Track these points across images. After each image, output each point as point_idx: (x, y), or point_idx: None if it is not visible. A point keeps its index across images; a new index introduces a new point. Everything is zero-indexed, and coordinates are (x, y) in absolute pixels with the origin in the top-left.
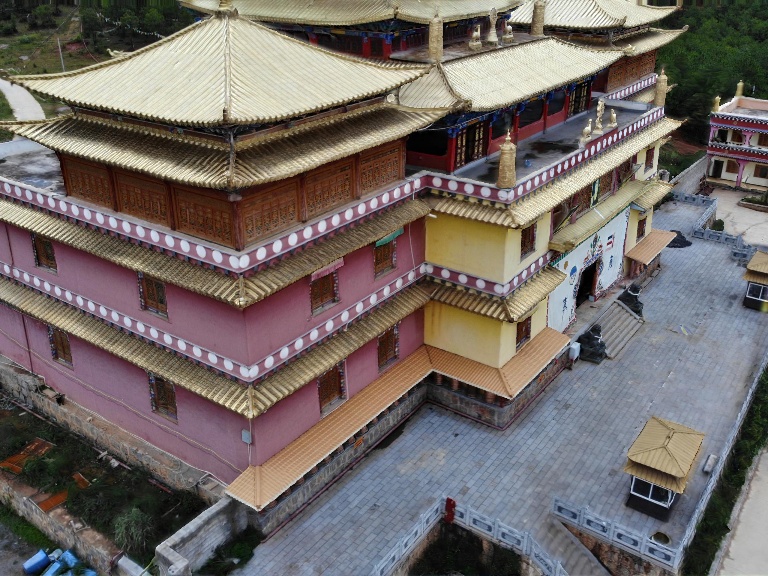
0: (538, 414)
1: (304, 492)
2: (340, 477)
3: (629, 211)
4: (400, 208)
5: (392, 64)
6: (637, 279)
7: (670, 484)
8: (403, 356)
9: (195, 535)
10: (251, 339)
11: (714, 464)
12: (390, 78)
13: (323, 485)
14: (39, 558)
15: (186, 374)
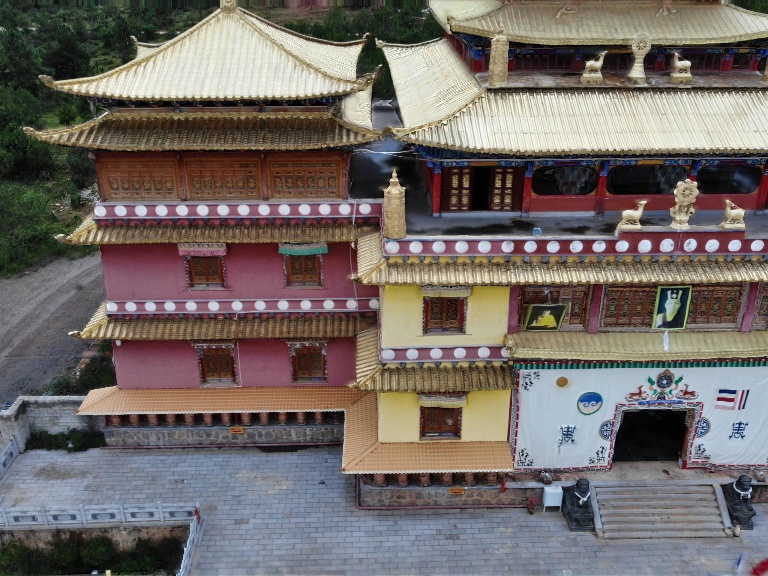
0: (414, 521)
1: (159, 436)
2: (203, 447)
3: None
4: (323, 225)
5: (471, 83)
6: None
7: None
8: (337, 383)
9: (50, 406)
10: (109, 279)
11: None
12: (317, 87)
13: (185, 443)
14: None
15: None
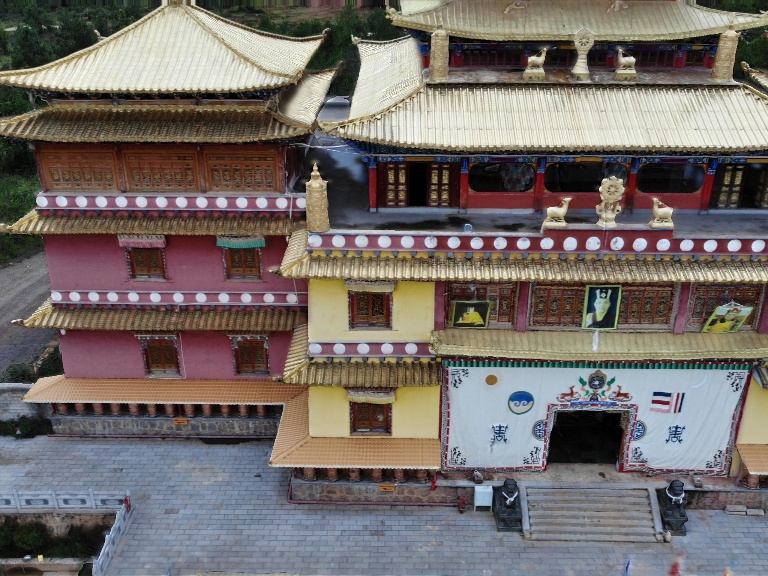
0: (342, 516)
1: (105, 425)
2: (148, 437)
3: (745, 378)
4: (259, 219)
5: None
6: (756, 492)
7: None
8: None
9: None
10: (53, 268)
11: None
12: (250, 81)
13: (130, 433)
14: None
15: None
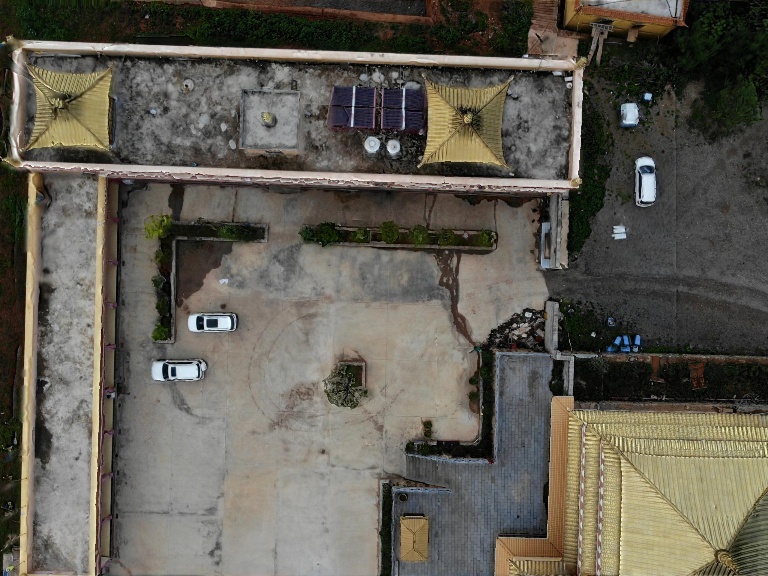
0: (489, 560)
1: None
2: None
3: None
4: (593, 568)
5: None
6: None
7: (406, 518)
8: None
9: None
10: None
11: (395, 568)
12: None
13: None
14: (637, 341)
15: (619, 417)
